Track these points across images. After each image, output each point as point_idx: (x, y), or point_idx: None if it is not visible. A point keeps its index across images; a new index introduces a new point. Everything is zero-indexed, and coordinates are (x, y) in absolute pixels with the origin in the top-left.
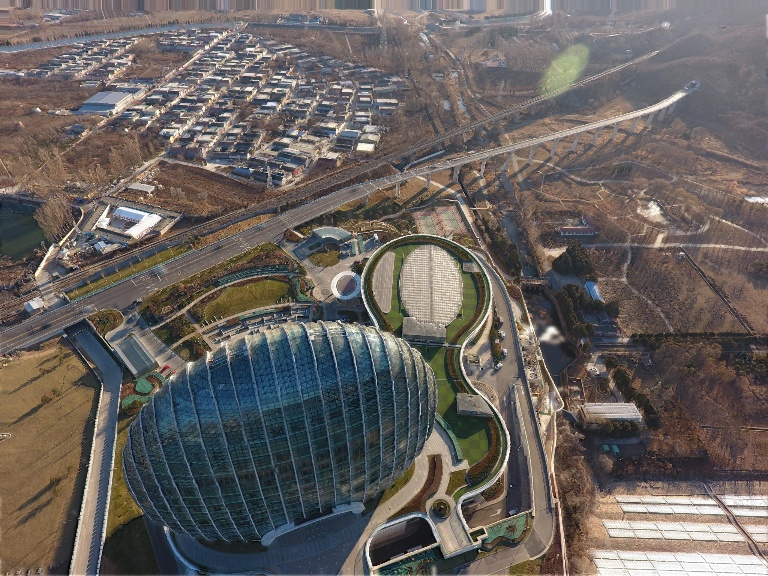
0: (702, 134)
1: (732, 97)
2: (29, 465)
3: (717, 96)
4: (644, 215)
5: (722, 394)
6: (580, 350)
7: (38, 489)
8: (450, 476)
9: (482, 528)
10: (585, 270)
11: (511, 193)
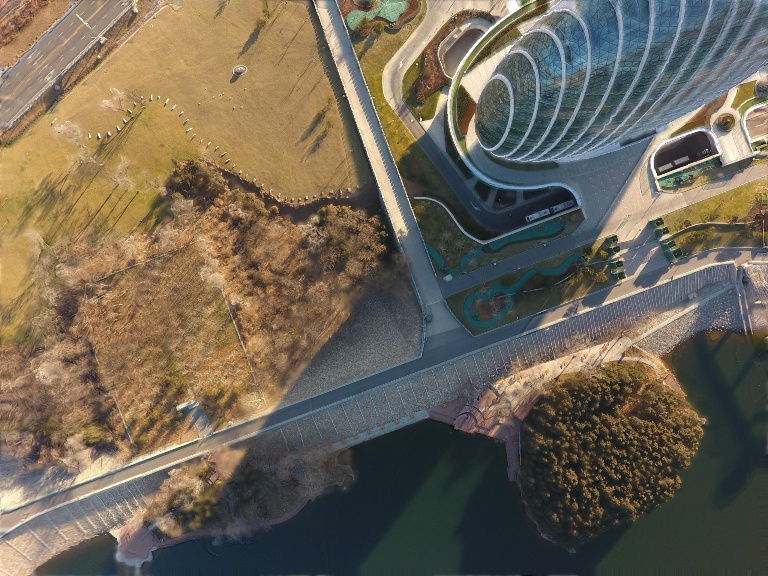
0: None
1: None
2: (285, 98)
3: None
4: None
5: None
6: None
7: (308, 122)
8: (738, 89)
9: (763, 139)
10: None
11: None
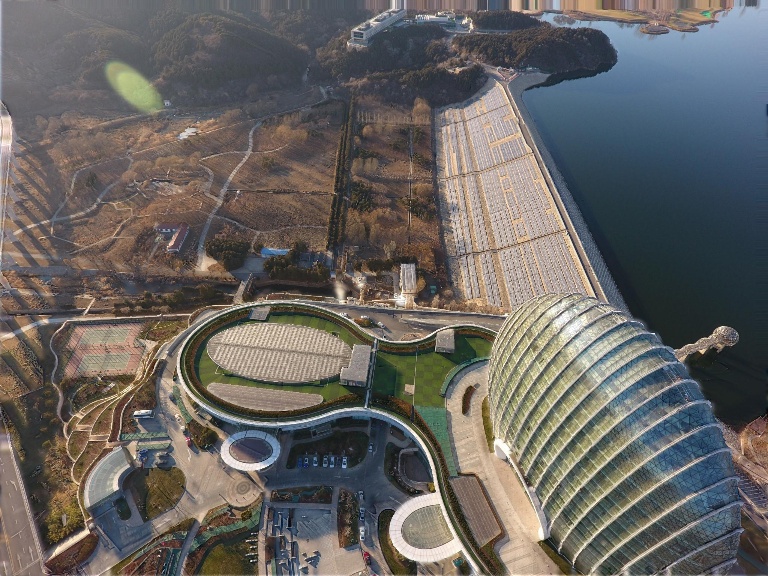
0: (75, 117)
1: (31, 79)
2: None
3: (19, 84)
4: (172, 193)
5: (383, 226)
6: (336, 282)
7: None
8: None
9: None
10: (246, 248)
11: (72, 271)
